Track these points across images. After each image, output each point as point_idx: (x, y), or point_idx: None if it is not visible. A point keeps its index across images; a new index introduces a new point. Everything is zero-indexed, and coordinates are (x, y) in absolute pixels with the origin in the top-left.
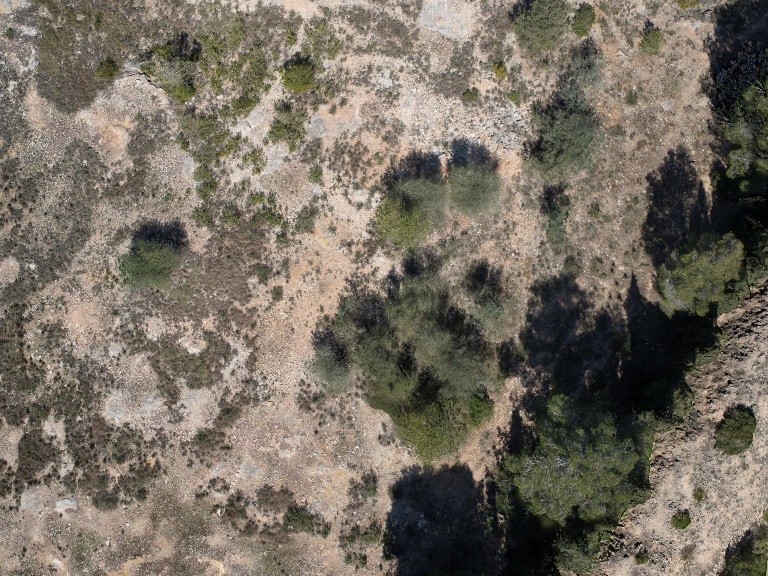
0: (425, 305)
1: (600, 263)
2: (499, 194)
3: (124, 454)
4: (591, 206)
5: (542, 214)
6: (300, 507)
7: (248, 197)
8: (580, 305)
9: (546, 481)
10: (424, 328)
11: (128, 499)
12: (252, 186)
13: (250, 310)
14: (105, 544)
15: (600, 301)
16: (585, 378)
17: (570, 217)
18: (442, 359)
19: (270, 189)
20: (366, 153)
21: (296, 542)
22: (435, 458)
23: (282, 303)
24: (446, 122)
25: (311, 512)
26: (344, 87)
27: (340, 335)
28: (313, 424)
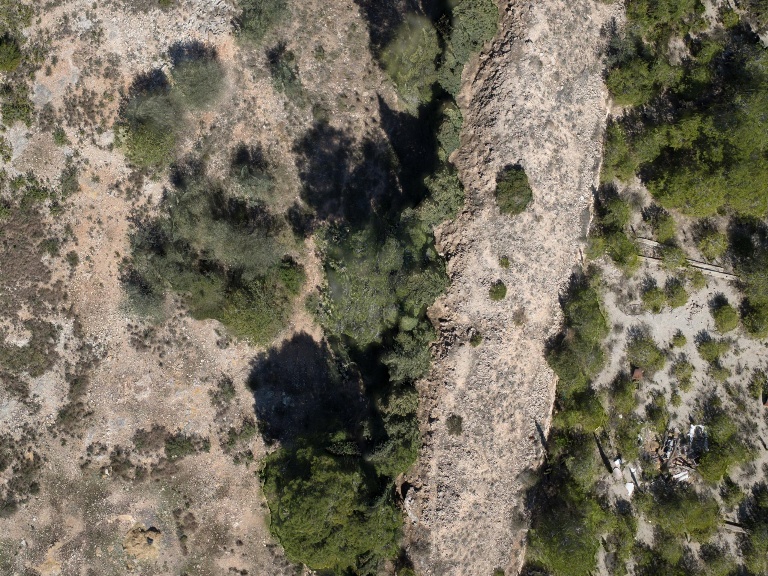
0: (198, 207)
1: (344, 98)
2: (229, 78)
3: (3, 461)
4: (315, 50)
5: (274, 78)
6: (175, 435)
7: (10, 185)
8: (342, 144)
9: (356, 311)
10: (213, 229)
11: (24, 498)
12: (9, 174)
13: (55, 285)
14: (22, 545)
15: (359, 132)
16: (372, 207)
17: (301, 69)
18: (241, 249)
19: (26, 169)
20: (95, 97)
21: (185, 467)
22: (273, 339)
23: (81, 265)
24: (155, 35)
25: (187, 435)
26: (50, 46)
27: (143, 270)
28: (155, 359)
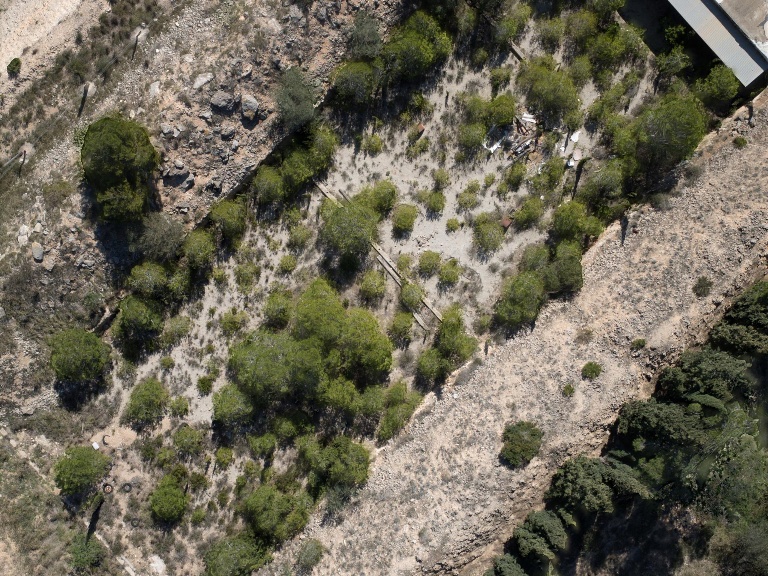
0: None
1: None
2: None
3: None
4: None
5: None
6: None
7: None
8: None
9: None
10: None
11: None
12: None
13: None
14: None
15: None
16: (632, 512)
17: None
18: None
19: None
20: None
21: None
22: None
23: None
24: None
25: None
26: None
27: None
28: None
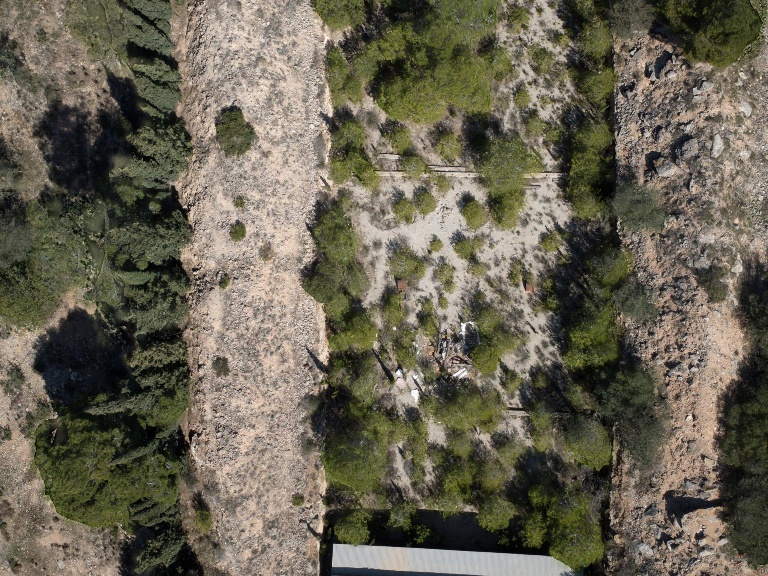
0: None
1: (72, 75)
2: None
3: None
4: (37, 34)
5: (4, 69)
6: None
7: None
8: (79, 120)
9: None
10: None
11: None
12: None
13: None
14: None
15: (93, 105)
16: None
17: (27, 55)
18: None
19: None
20: None
21: None
22: (50, 320)
23: None
24: None
25: None
26: None
27: None
28: None
